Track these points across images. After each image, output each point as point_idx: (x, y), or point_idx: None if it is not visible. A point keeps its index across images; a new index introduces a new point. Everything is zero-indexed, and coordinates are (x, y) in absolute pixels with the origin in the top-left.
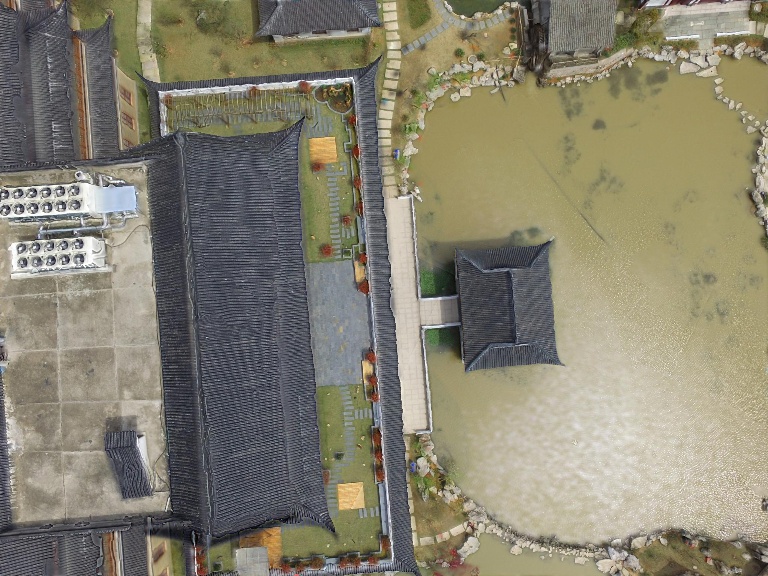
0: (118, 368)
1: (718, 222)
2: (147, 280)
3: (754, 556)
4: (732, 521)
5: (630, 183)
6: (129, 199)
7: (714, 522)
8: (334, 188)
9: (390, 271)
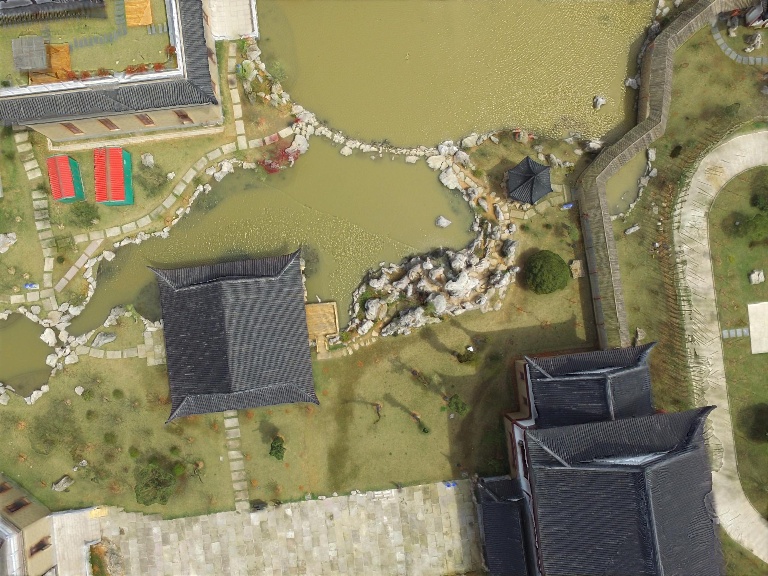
0: None
1: None
2: None
3: (585, 148)
4: (564, 121)
5: None
6: None
7: (546, 122)
8: None
9: None
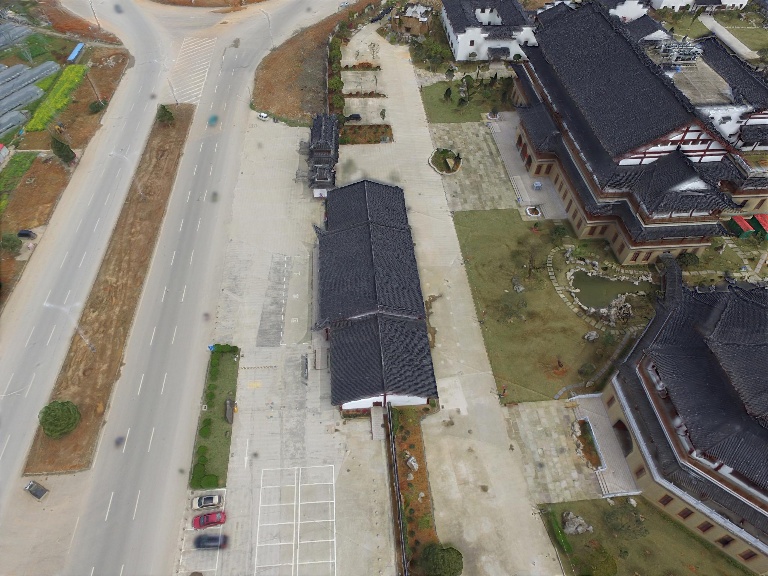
0: (713, 84)
1: None
2: None
3: None
4: None
5: None
6: (701, 50)
7: None
8: None
9: None
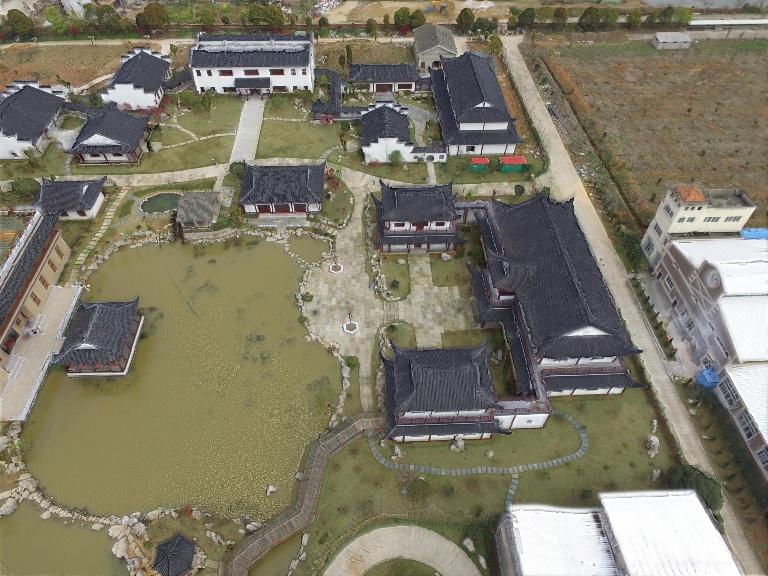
0: None
1: (272, 308)
2: None
3: None
4: (239, 502)
5: (223, 288)
6: None
7: (224, 502)
8: (2, 253)
9: None
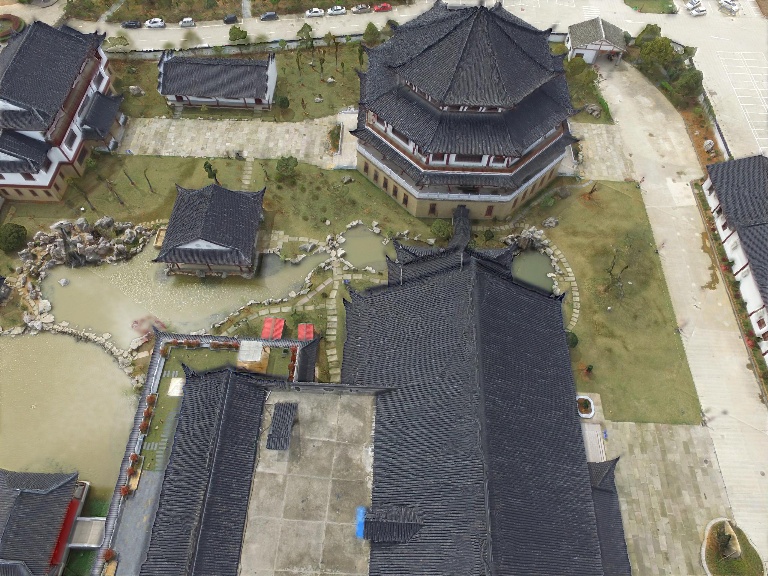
0: (283, 501)
1: None
2: (245, 575)
3: None
4: None
5: None
6: None
7: None
8: None
9: (93, 571)
